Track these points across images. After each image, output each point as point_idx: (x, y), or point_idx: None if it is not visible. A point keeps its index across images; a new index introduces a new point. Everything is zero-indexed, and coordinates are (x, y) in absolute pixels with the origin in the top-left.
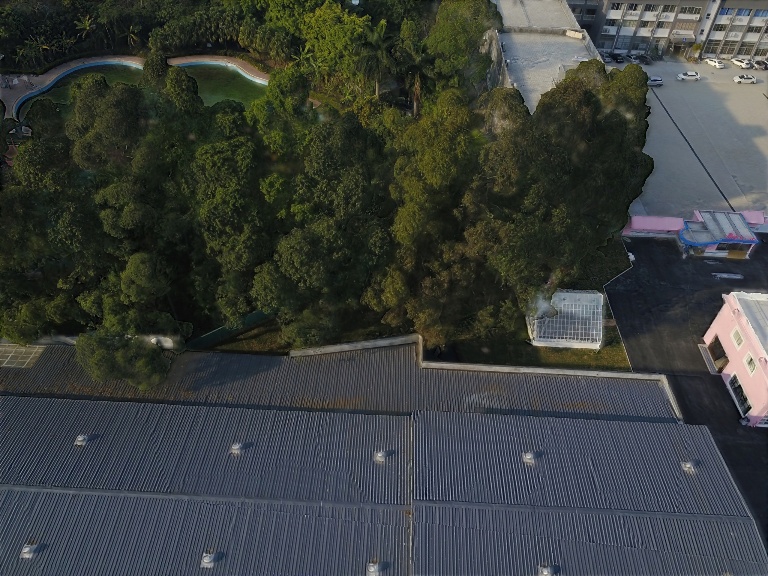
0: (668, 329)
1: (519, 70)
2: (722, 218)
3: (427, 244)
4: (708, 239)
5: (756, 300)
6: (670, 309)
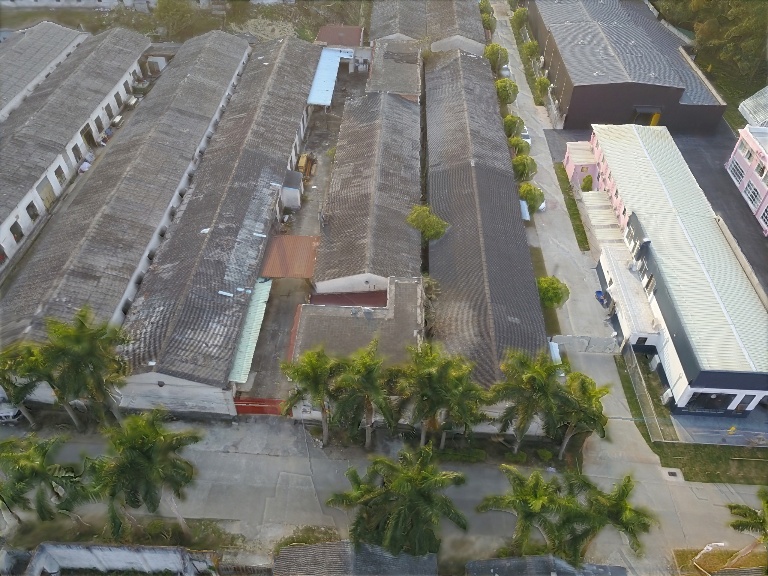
0: None
1: None
2: None
3: None
4: None
5: None
6: None
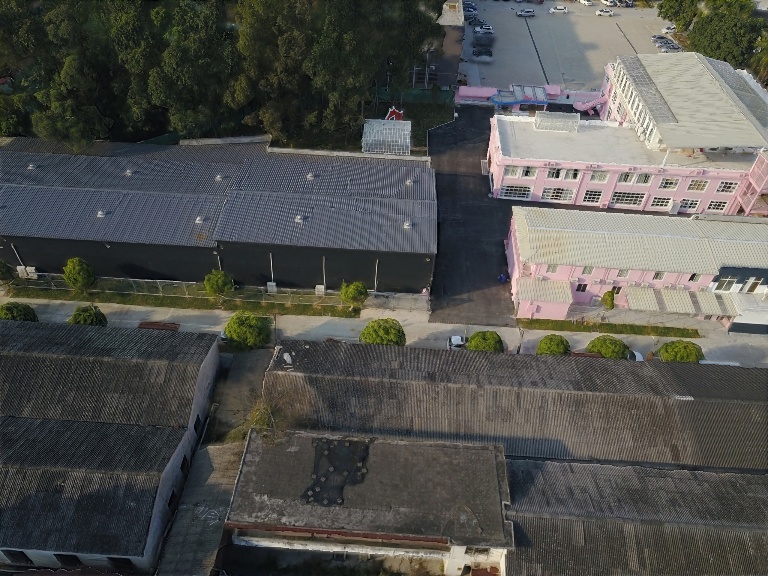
0: (464, 153)
1: None
2: (528, 90)
3: (268, 63)
4: (511, 101)
5: (512, 121)
6: (471, 143)
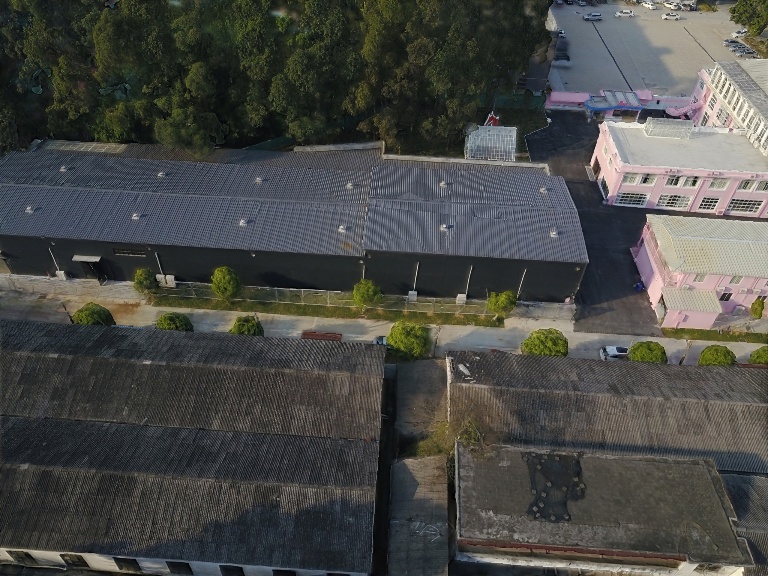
0: (566, 159)
1: None
2: (620, 95)
3: (387, 70)
4: (605, 106)
5: (621, 127)
6: (571, 149)
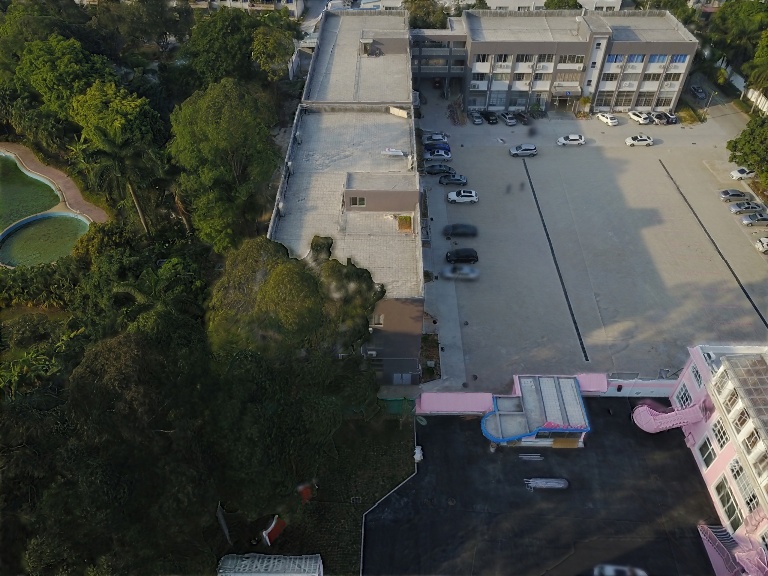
0: None
1: (307, 174)
2: (549, 387)
3: None
4: (520, 429)
5: None
6: (448, 556)
